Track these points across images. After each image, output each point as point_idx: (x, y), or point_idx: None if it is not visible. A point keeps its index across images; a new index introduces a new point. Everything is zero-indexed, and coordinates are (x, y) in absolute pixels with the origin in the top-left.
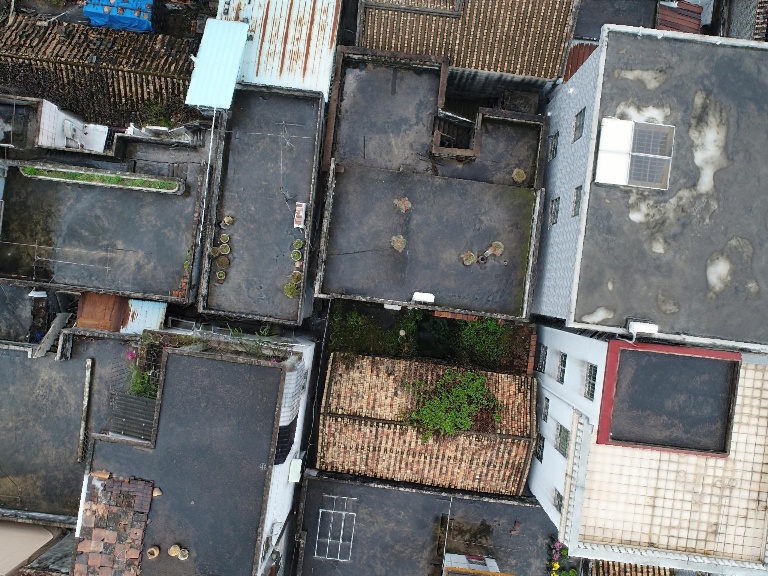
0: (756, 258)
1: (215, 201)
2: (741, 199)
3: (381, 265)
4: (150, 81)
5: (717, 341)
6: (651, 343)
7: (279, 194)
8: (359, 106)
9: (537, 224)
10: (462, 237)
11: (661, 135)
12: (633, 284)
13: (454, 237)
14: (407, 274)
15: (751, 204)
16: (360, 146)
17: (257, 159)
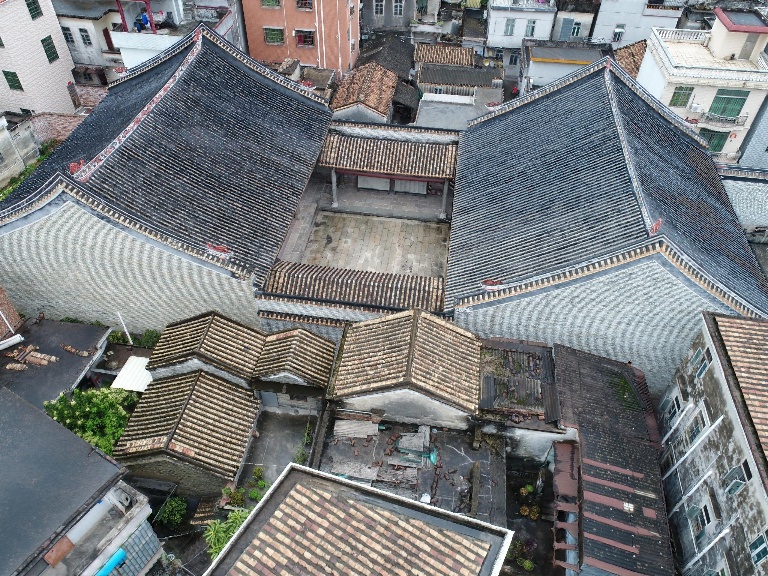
0: None
1: (725, 5)
2: None
3: None
4: None
5: None
6: None
7: None
8: None
9: None
10: None
11: None
12: None
13: None
14: None
15: None
16: None
17: None
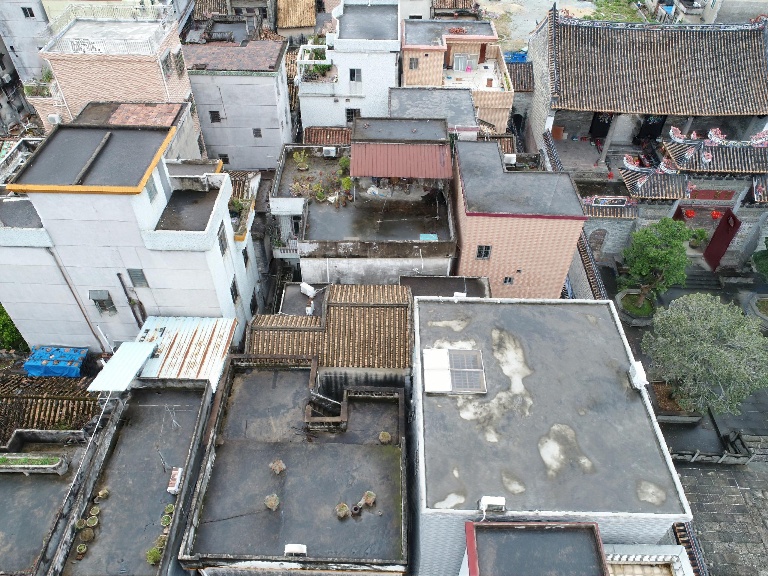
0: (579, 438)
1: (94, 476)
2: (550, 395)
3: (255, 528)
4: (65, 405)
5: (569, 513)
6: (506, 521)
7: (159, 467)
8: (244, 399)
9: (402, 467)
10: (336, 493)
11: (471, 356)
12: (477, 470)
13: (328, 494)
14: (281, 534)
15: (560, 398)
16: (242, 428)
17: (144, 440)
